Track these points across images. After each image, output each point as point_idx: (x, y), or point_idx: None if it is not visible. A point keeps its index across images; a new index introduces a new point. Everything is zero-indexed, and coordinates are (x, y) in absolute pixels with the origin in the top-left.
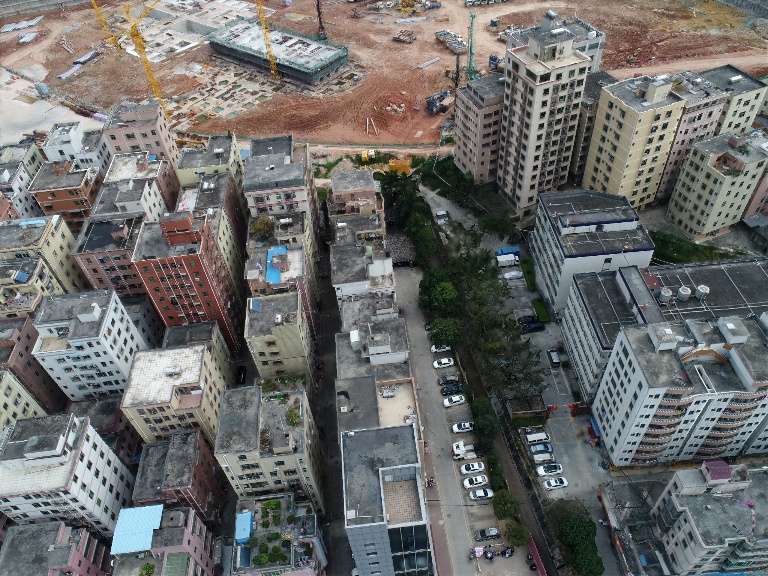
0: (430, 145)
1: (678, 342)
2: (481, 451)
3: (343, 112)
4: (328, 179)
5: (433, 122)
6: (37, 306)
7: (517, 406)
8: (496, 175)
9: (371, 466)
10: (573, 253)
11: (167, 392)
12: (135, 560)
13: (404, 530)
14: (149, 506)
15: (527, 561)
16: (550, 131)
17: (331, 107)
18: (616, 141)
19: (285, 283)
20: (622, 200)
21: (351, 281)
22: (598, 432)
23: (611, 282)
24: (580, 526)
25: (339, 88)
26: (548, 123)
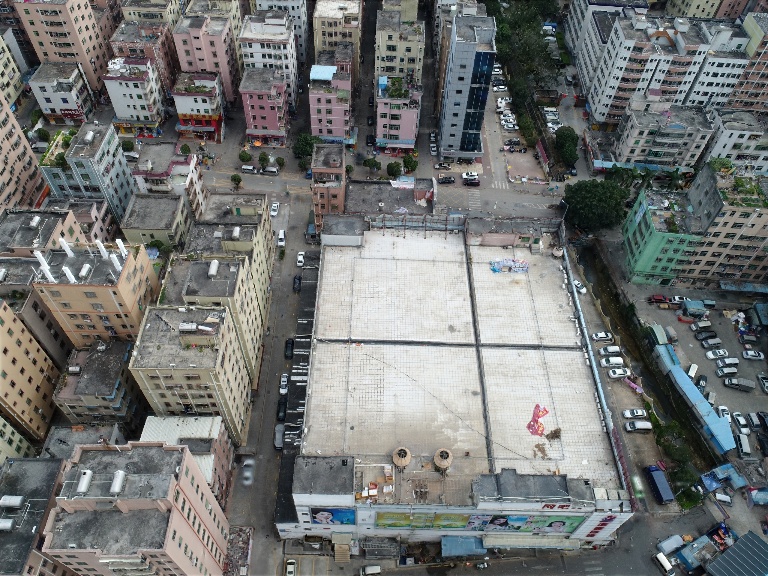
0: None
1: None
2: (514, 110)
3: None
4: None
5: None
6: None
7: (541, 93)
8: None
9: (470, 27)
10: None
11: (340, 15)
12: (320, 88)
13: (483, 56)
14: (329, 66)
15: (534, 154)
16: None
17: None
18: None
19: None
20: None
21: None
22: (589, 109)
23: None
24: (569, 134)
25: None
26: None
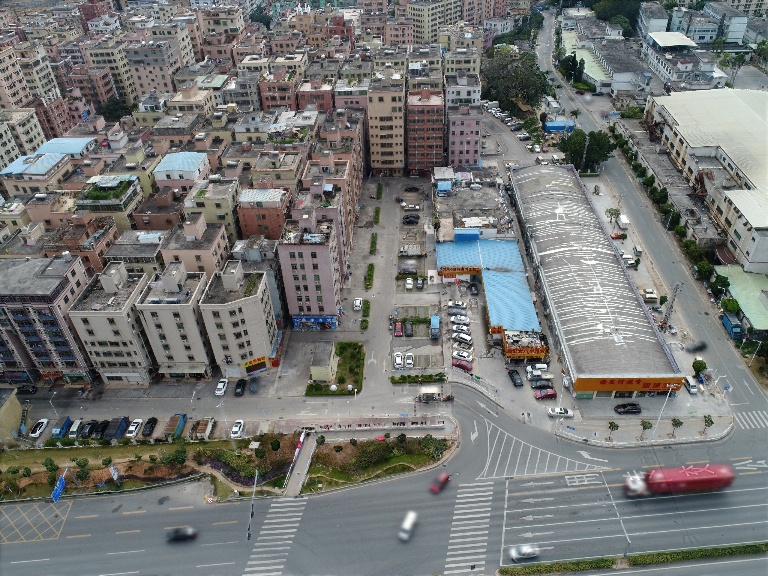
0: None
1: None
2: None
3: None
4: None
5: None
6: None
7: None
8: None
9: None
10: None
11: None
12: None
13: None
14: None
15: None
16: None
17: None
18: None
19: None
20: None
21: None
22: None
23: None
24: None
25: None
26: None
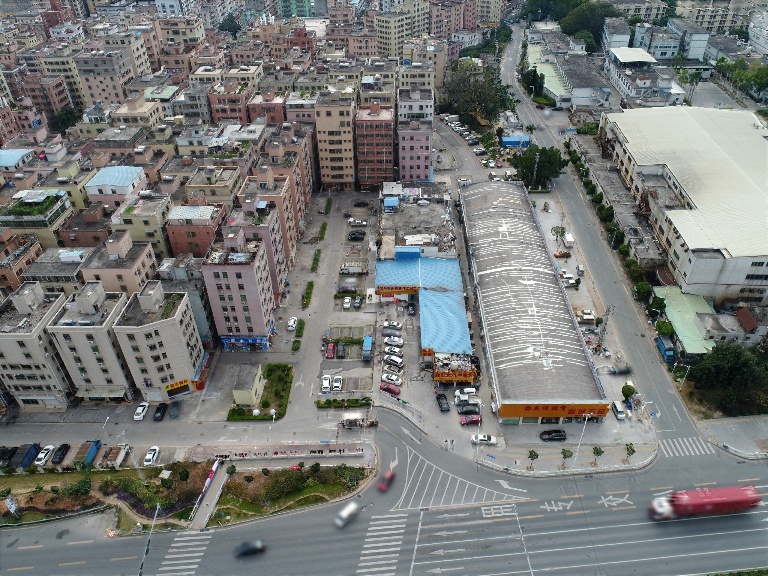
0: None
1: None
2: None
3: None
4: None
5: None
6: None
7: None
8: None
9: None
10: None
11: None
12: None
13: None
14: None
15: None
16: None
17: None
18: None
19: None
20: None
21: None
22: None
23: None
24: None
25: None
26: None
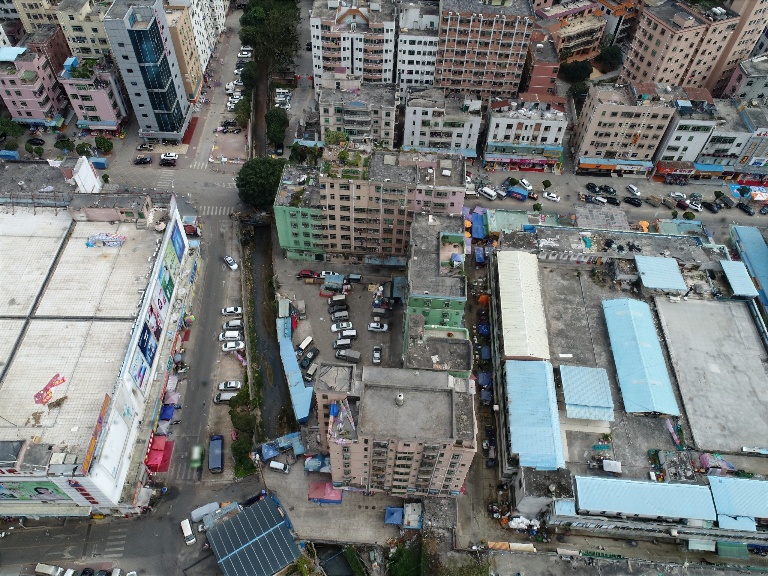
0: None
1: None
2: (245, 92)
3: None
4: None
5: None
6: None
7: (277, 75)
8: None
9: (128, 5)
10: None
11: None
12: (6, 70)
13: (137, 34)
14: None
15: (245, 135)
16: None
17: None
18: None
19: None
20: None
21: None
22: None
23: None
24: (275, 113)
25: None
26: None
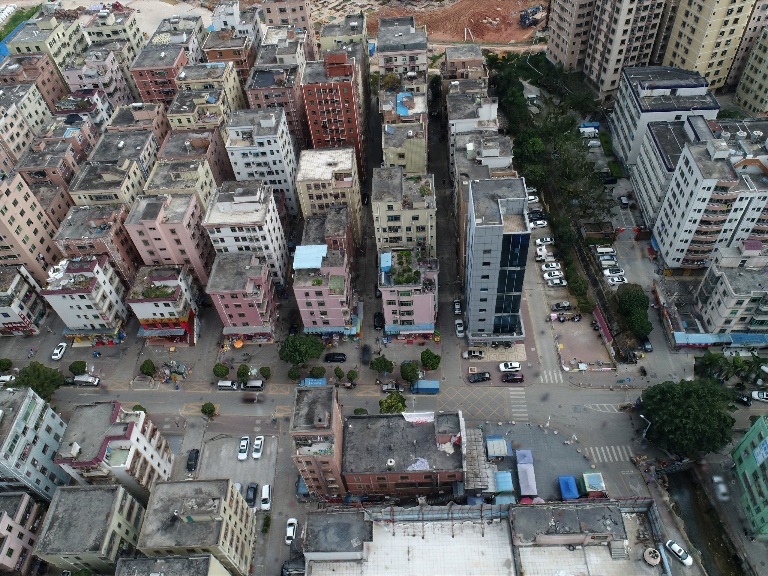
0: (524, 44)
1: (731, 155)
2: (559, 256)
3: (443, 23)
4: (433, 69)
5: (525, 33)
6: (221, 123)
7: (590, 228)
8: (583, 66)
9: (492, 198)
10: (649, 109)
11: (328, 174)
12: (308, 277)
13: (514, 238)
14: (317, 245)
15: (591, 324)
16: (637, 17)
17: (432, 19)
18: (695, 24)
19: (412, 115)
20: (695, 75)
21: (464, 119)
22: (656, 247)
23: (679, 129)
24: (637, 297)
25: (439, 4)
26: (636, 9)
